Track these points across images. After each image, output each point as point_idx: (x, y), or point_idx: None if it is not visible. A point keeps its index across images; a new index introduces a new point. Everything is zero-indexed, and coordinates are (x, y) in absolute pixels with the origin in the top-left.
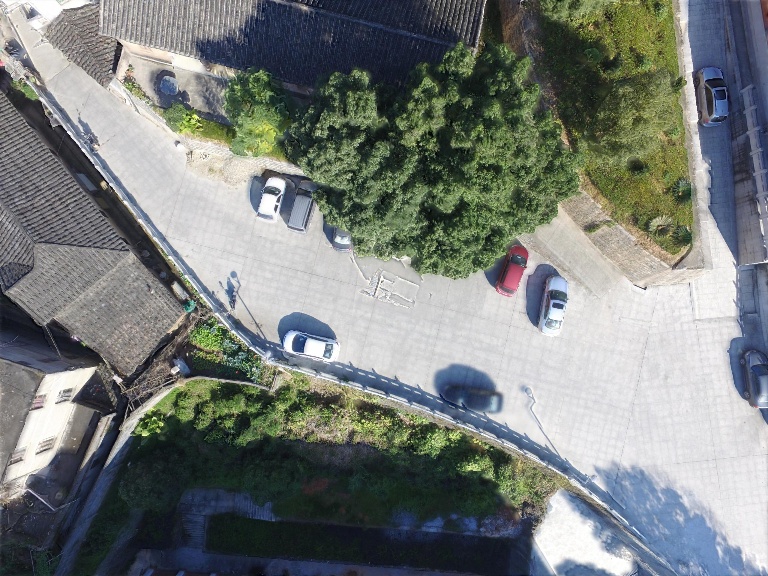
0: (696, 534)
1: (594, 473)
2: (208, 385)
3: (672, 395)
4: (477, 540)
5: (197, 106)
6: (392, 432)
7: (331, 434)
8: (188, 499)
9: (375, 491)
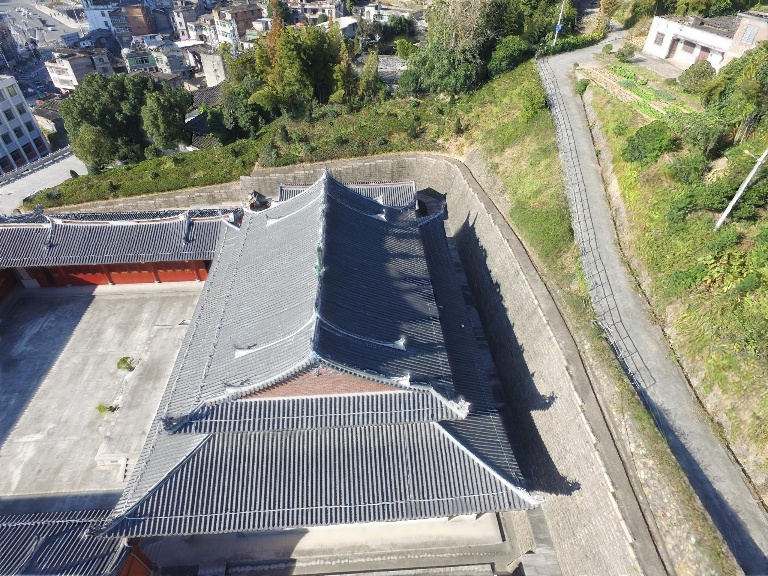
0: None
1: None
2: None
3: None
4: None
5: None
6: None
7: None
8: None
9: None
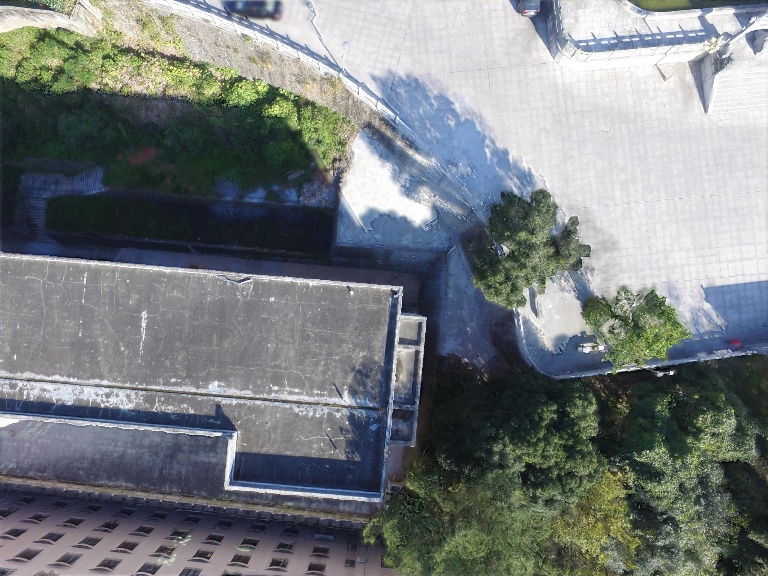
0: (466, 137)
1: (370, 81)
2: (26, 38)
3: (448, 9)
4: (300, 215)
5: None
6: (200, 80)
7: (143, 85)
8: (29, 183)
9: (187, 142)
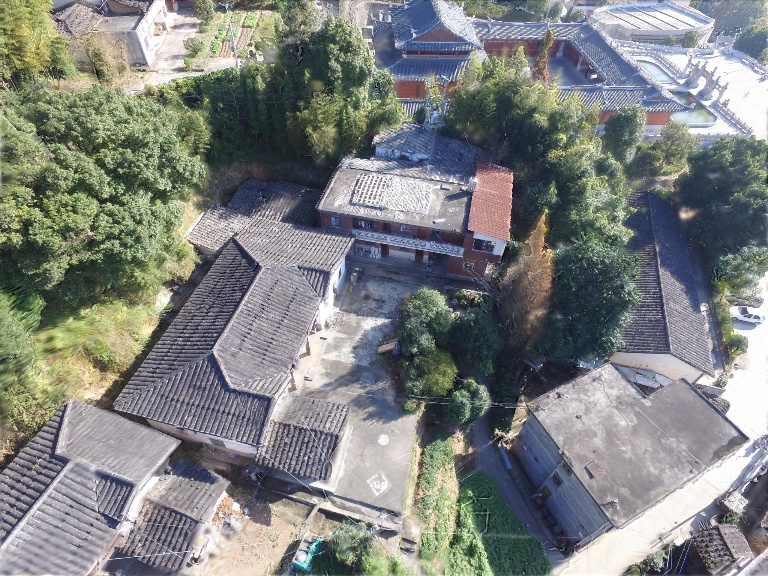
0: None
1: None
2: None
3: None
4: None
5: (710, 346)
6: None
7: None
8: None
9: None
